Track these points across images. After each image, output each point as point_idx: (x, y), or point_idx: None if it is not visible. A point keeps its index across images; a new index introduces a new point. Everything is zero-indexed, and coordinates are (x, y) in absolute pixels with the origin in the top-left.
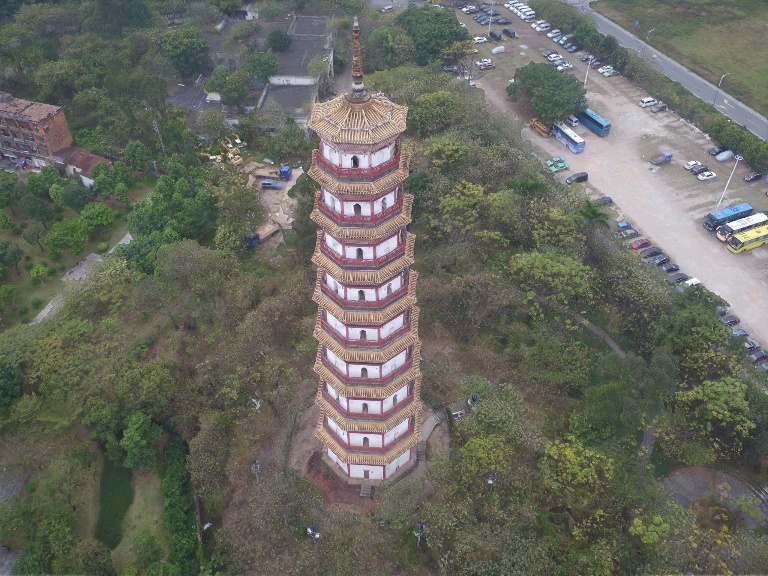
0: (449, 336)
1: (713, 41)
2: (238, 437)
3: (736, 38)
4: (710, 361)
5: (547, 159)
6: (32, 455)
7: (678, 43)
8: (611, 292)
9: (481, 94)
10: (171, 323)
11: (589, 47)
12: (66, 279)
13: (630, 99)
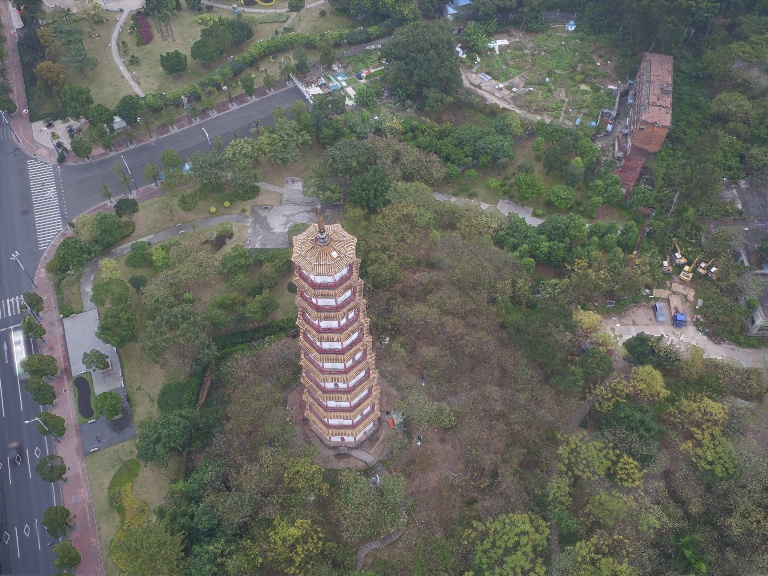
0: (469, 477)
1: None
2: None
3: None
4: None
5: None
6: None
7: None
8: None
9: None
10: None
11: None
12: (480, 199)
13: None
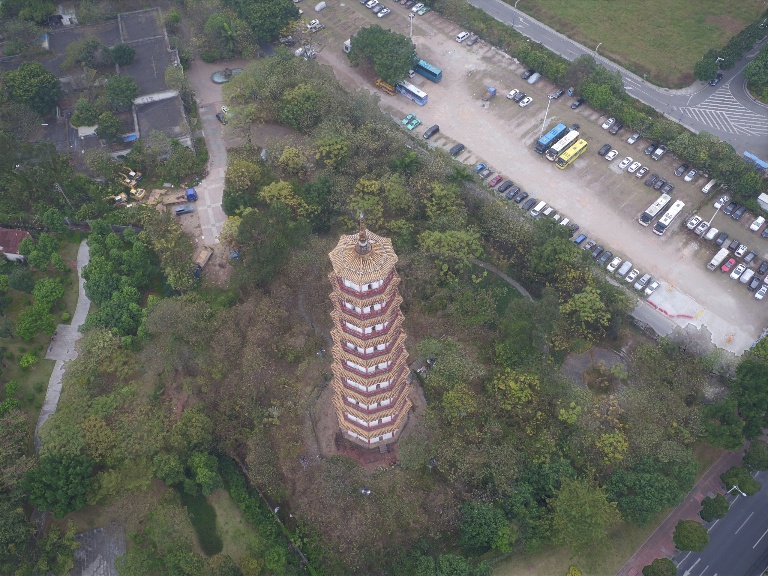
0: None
1: None
2: (276, 443)
3: None
4: (574, 279)
5: (401, 118)
6: (137, 515)
7: None
8: (492, 239)
9: (330, 71)
10: (172, 369)
11: None
12: None
13: (447, 36)
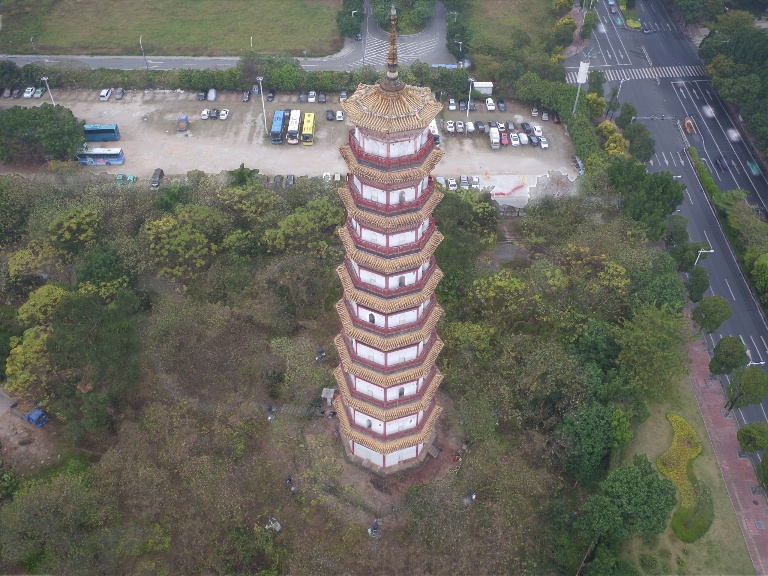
0: (289, 335)
1: (70, 26)
2: None
3: (82, 15)
4: None
5: None
6: None
7: (48, 41)
8: None
9: None
10: None
11: None
12: None
13: (87, 101)
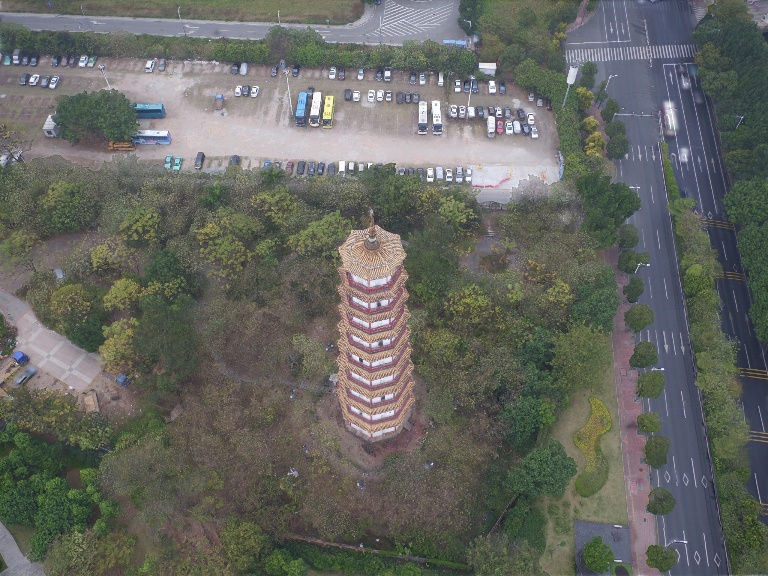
0: None
1: None
2: None
3: None
4: (429, 200)
5: None
6: None
7: None
8: None
9: (62, 159)
10: None
11: (46, 51)
12: None
13: (134, 72)
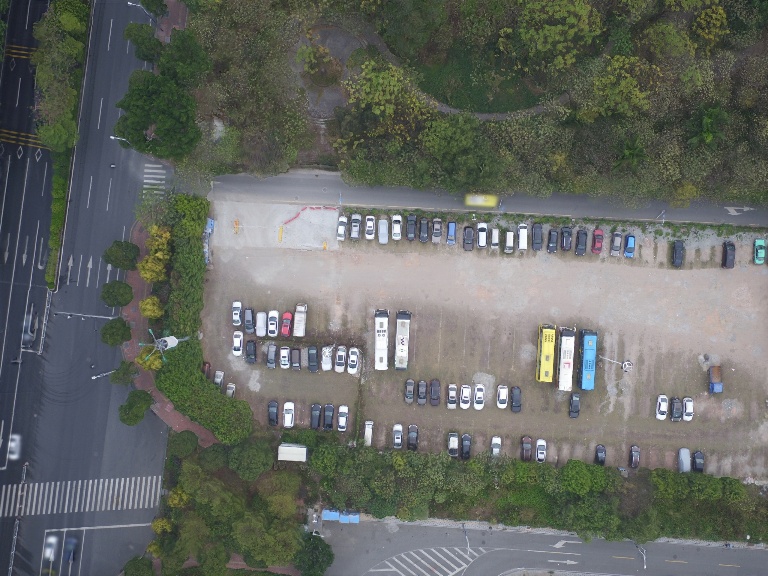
0: None
1: None
2: None
3: None
4: (410, 103)
5: None
6: None
7: None
8: None
9: None
10: None
11: None
12: None
13: None
